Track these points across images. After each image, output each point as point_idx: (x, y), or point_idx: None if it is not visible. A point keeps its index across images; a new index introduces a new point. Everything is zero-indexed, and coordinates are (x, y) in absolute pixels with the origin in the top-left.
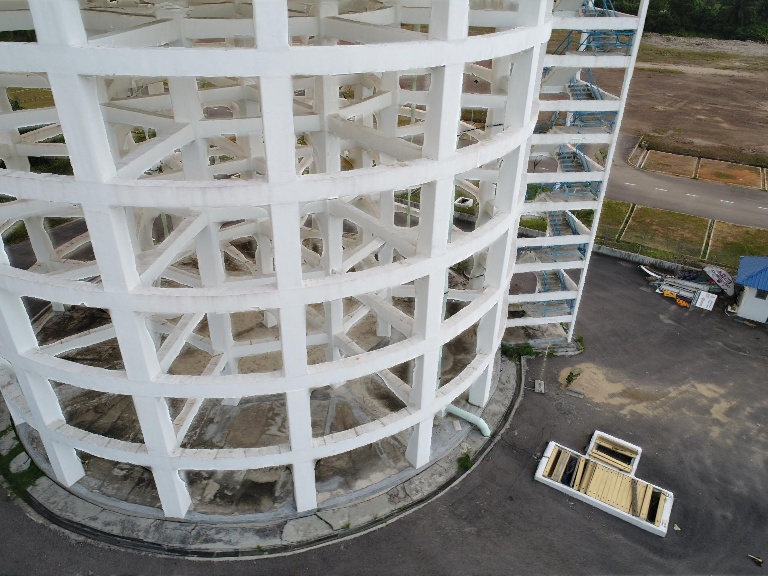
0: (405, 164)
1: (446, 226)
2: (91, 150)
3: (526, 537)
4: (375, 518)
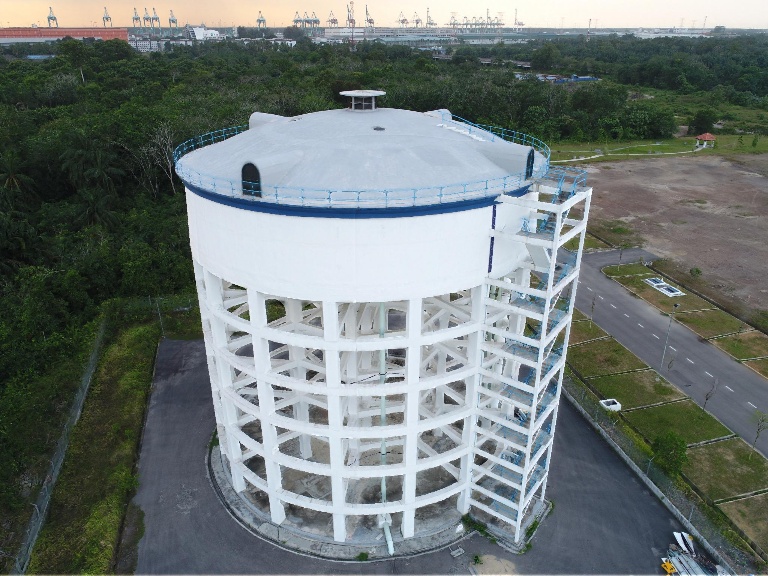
0: (312, 383)
1: (337, 418)
2: (216, 337)
3: None
4: (298, 548)
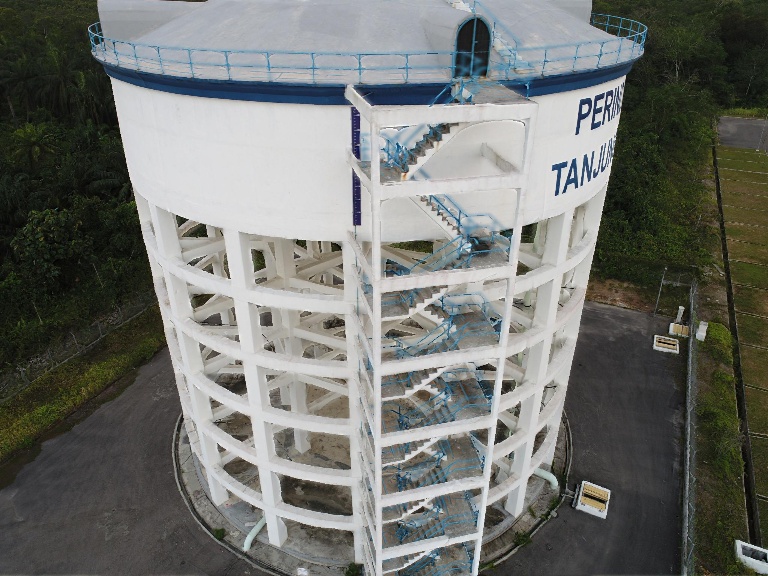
0: (169, 304)
1: None
2: None
3: (149, 570)
4: None
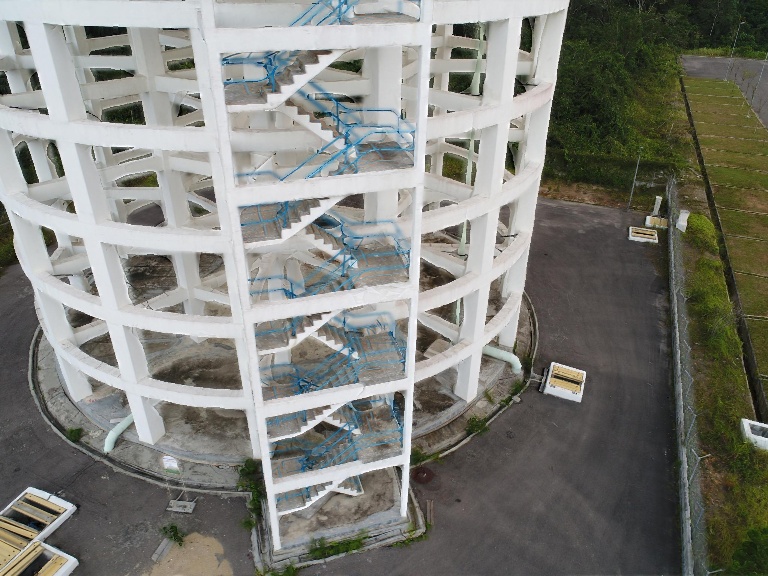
0: None
1: None
2: None
3: None
4: None
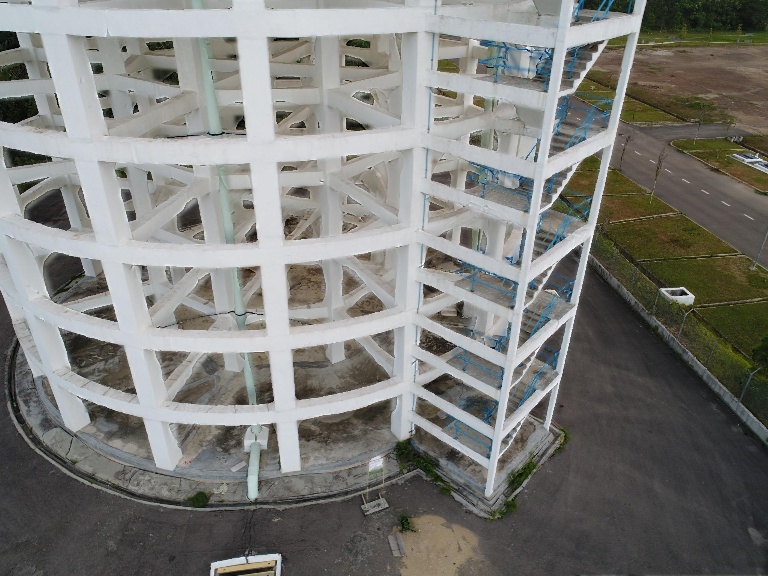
0: (44, 131)
1: (106, 215)
2: None
3: None
4: (93, 474)
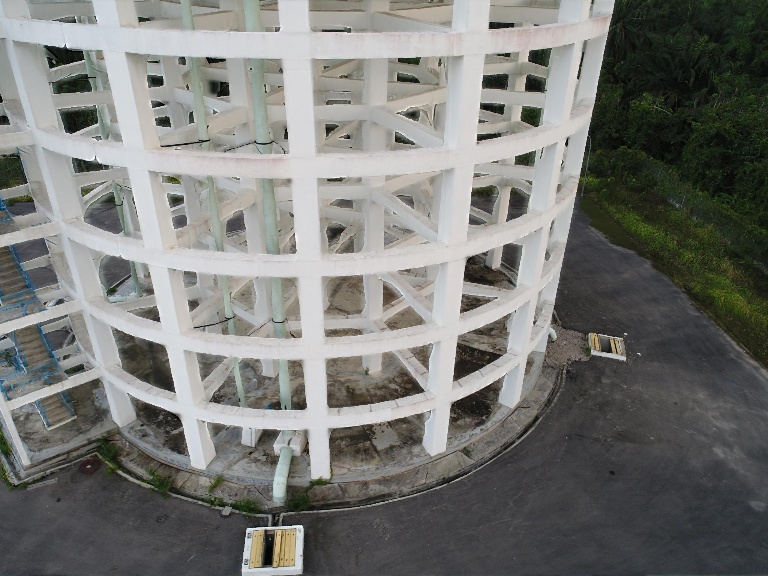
0: None
1: None
2: None
3: None
4: None
